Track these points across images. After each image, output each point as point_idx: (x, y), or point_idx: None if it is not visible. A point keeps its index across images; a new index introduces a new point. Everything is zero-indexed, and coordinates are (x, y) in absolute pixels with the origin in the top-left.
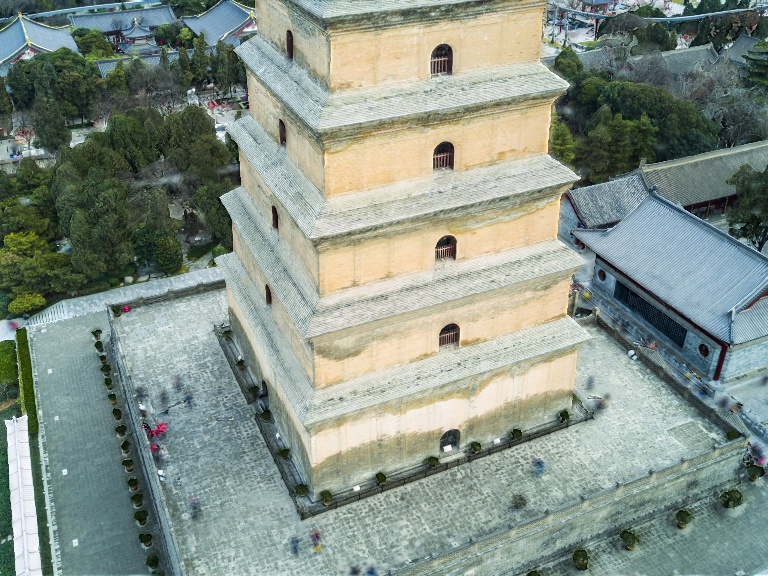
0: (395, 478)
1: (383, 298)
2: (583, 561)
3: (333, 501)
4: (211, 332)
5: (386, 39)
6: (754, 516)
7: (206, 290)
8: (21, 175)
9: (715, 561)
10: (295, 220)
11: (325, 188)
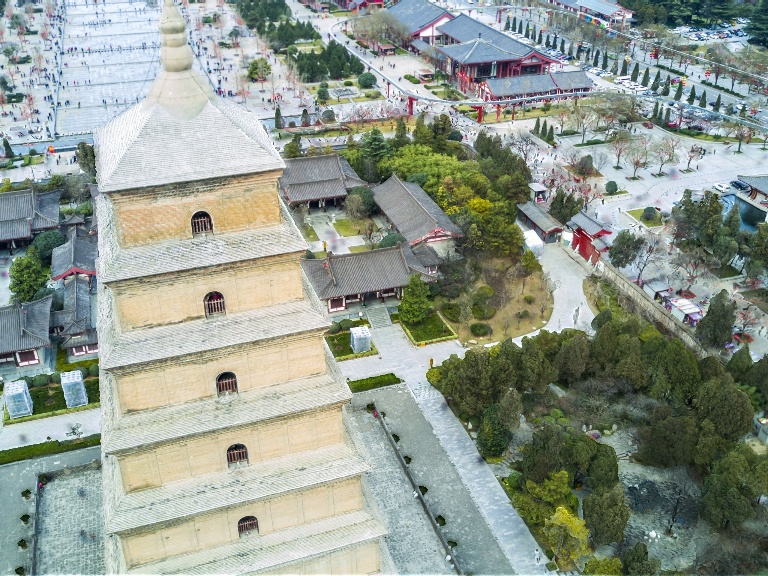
0: None
1: None
2: None
3: None
4: None
5: None
6: None
7: None
8: None
9: None
10: None
11: None
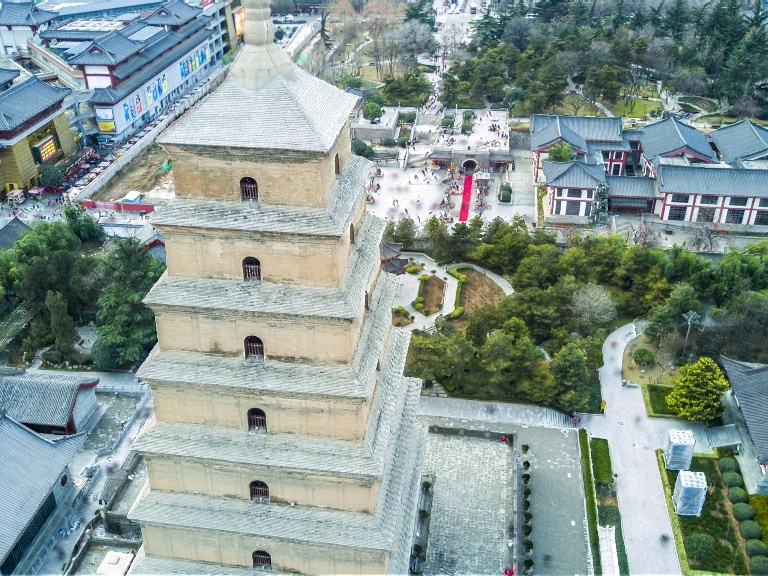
0: None
1: None
2: None
3: None
4: None
5: None
6: None
7: None
8: None
9: None
10: None
11: None
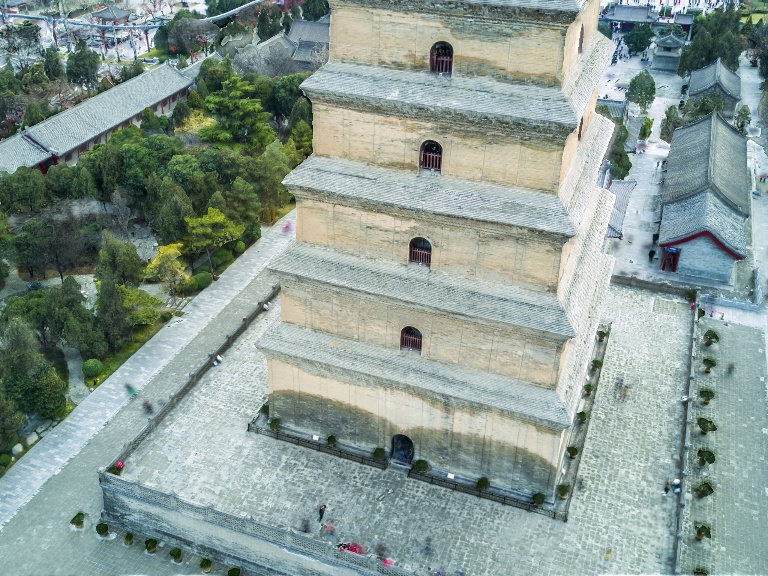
0: (572, 446)
1: (577, 276)
2: (711, 425)
3: (571, 490)
4: (248, 434)
5: (575, 26)
6: (724, 342)
7: (178, 400)
8: None
9: (745, 380)
10: (534, 227)
11: (558, 184)
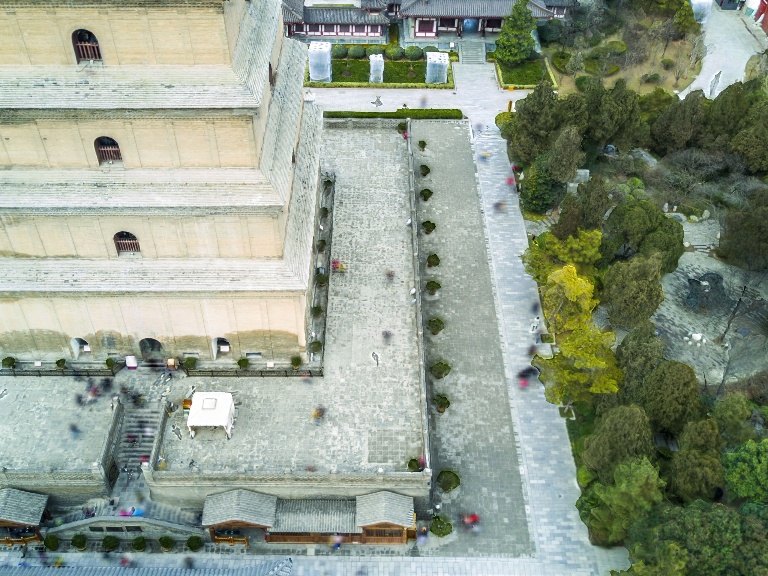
0: None
1: None
2: None
3: None
4: None
5: None
6: None
7: None
8: (748, 95)
9: None
10: None
11: None
